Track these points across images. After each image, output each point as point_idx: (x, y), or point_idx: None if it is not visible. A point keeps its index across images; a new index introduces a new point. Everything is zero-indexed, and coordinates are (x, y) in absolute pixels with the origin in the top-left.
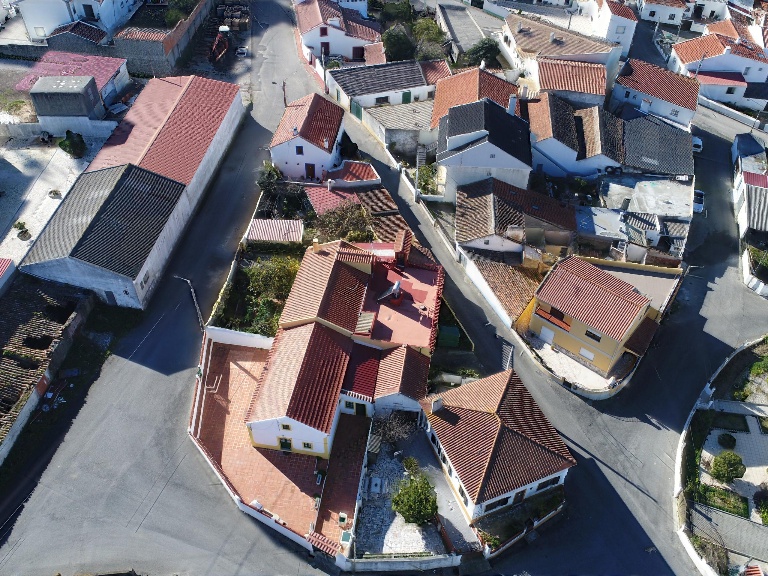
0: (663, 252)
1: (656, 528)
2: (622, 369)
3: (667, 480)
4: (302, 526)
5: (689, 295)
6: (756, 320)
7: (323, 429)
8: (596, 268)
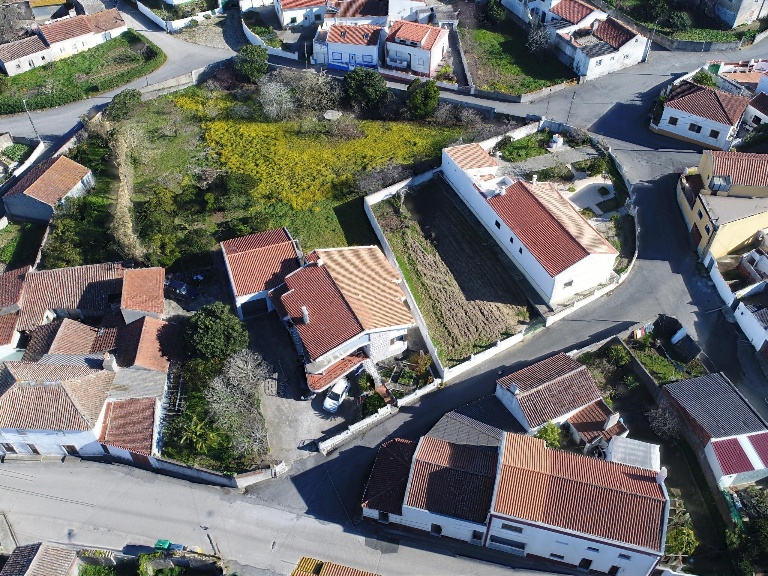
0: (752, 285)
1: (607, 141)
2: (688, 194)
3: (618, 160)
4: (730, 75)
5: (701, 287)
6: (643, 294)
7: (767, 73)
8: (766, 184)
